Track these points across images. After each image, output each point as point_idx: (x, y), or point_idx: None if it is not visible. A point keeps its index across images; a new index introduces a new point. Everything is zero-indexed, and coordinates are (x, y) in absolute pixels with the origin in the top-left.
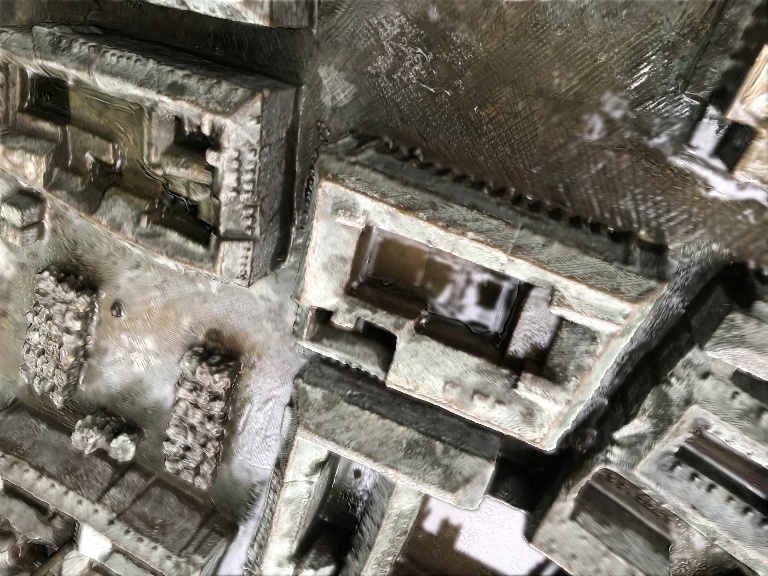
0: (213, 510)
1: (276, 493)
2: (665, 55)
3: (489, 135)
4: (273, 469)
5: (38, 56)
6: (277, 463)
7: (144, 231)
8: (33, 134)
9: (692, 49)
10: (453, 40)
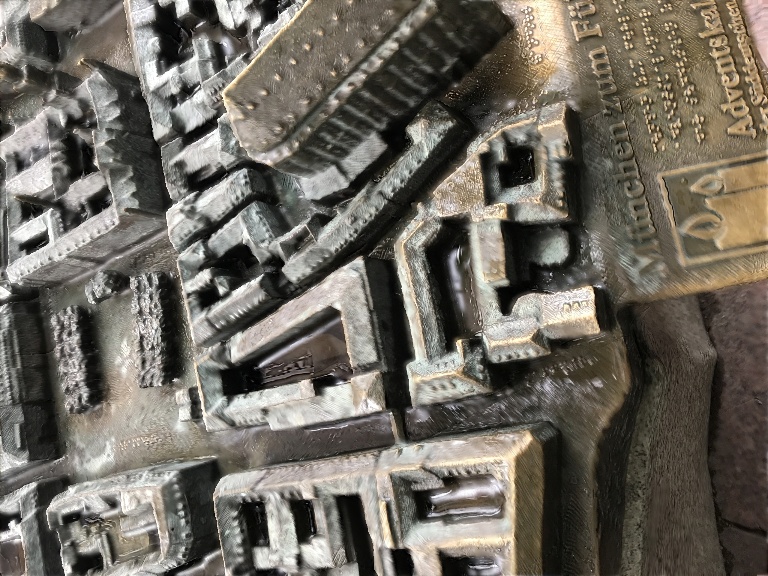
0: (62, 284)
1: (1, 393)
2: None
3: None
4: (18, 393)
5: (140, 572)
6: (14, 403)
7: (82, 502)
8: (146, 513)
9: None
10: None
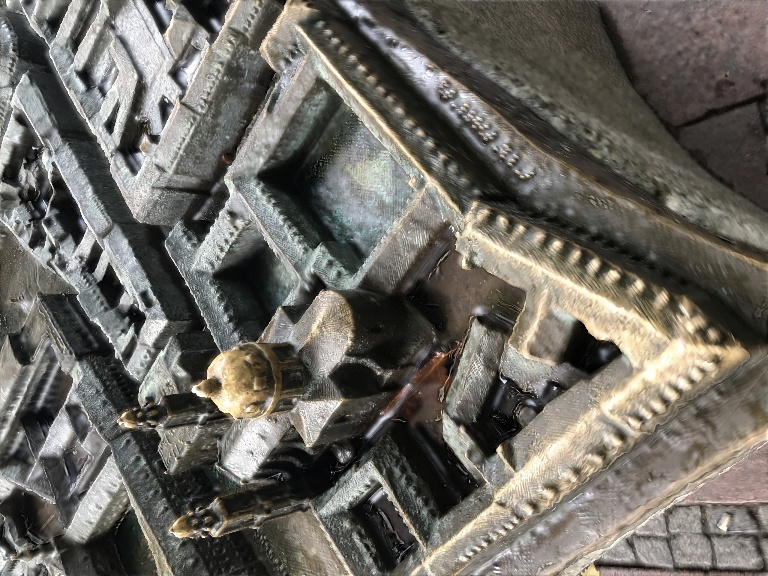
0: None
1: None
2: (6, 331)
3: (5, 264)
4: None
5: None
6: None
7: None
8: None
9: (4, 339)
10: (21, 265)
